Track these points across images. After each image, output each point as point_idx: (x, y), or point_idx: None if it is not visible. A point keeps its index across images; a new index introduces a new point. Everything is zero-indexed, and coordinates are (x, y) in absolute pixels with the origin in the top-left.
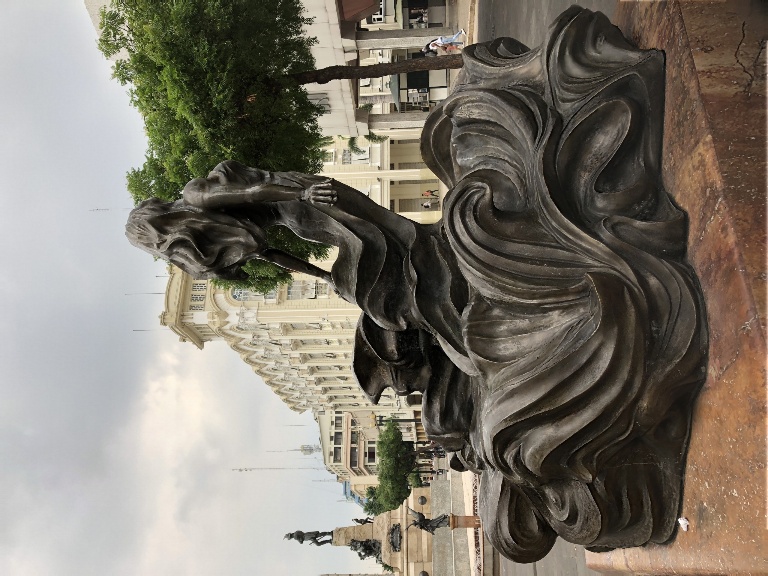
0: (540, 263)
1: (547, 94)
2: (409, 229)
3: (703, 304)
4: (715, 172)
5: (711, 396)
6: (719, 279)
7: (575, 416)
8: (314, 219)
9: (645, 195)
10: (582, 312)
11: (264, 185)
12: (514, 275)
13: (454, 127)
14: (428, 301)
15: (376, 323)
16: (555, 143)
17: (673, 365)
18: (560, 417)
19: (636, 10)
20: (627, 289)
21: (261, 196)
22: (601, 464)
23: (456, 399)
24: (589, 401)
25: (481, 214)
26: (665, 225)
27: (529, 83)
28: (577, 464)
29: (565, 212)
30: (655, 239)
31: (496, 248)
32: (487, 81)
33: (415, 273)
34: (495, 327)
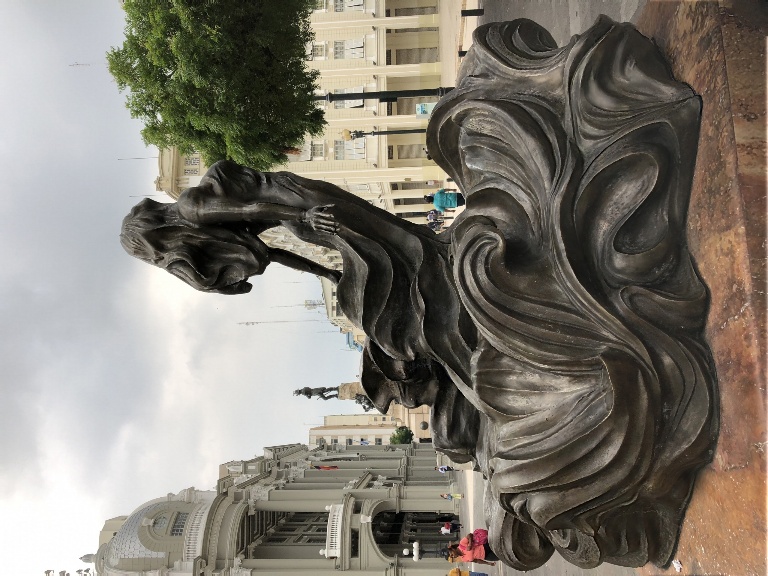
0: (553, 328)
1: (567, 121)
2: (416, 246)
3: (717, 393)
4: (745, 272)
5: (716, 479)
6: (737, 382)
7: (581, 489)
8: (316, 232)
9: (667, 257)
10: (594, 383)
11: (262, 205)
12: (526, 338)
13: (463, 133)
14: (436, 330)
15: (384, 351)
16: (574, 189)
17: (681, 451)
18: (567, 488)
19: (673, 23)
20: (641, 373)
21: (259, 216)
22: (603, 519)
23: (463, 411)
24: (596, 479)
25: (493, 266)
26: (685, 304)
27: (547, 96)
28: (580, 520)
29: (581, 275)
30: (674, 315)
31: (508, 305)
32: (500, 79)
33: (423, 301)
34: (504, 375)
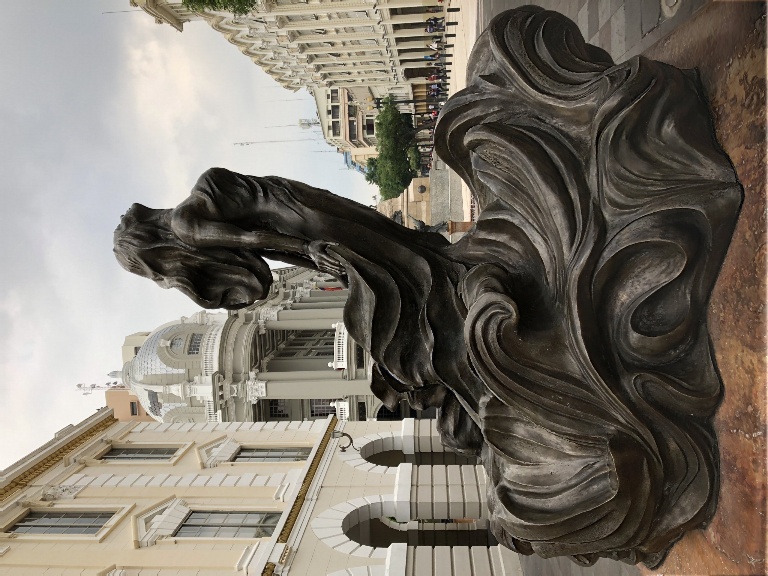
0: (563, 400)
1: (592, 176)
2: (424, 269)
3: (718, 482)
4: (762, 402)
5: (706, 547)
6: (738, 490)
7: (581, 544)
8: None
9: (684, 339)
10: (599, 454)
11: (261, 236)
12: (535, 406)
13: None
14: (445, 359)
15: None
16: (594, 262)
17: (677, 526)
18: None
19: (723, 74)
20: (647, 462)
21: (260, 247)
22: None
23: None
24: None
25: (505, 334)
26: (698, 401)
27: (571, 133)
28: None
29: (595, 356)
30: (685, 405)
31: (519, 373)
32: (519, 92)
33: (431, 332)
34: (512, 421)
